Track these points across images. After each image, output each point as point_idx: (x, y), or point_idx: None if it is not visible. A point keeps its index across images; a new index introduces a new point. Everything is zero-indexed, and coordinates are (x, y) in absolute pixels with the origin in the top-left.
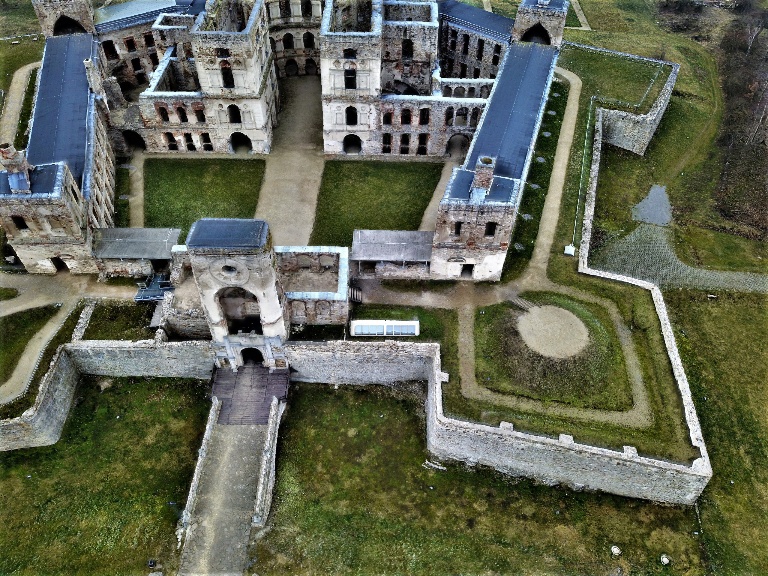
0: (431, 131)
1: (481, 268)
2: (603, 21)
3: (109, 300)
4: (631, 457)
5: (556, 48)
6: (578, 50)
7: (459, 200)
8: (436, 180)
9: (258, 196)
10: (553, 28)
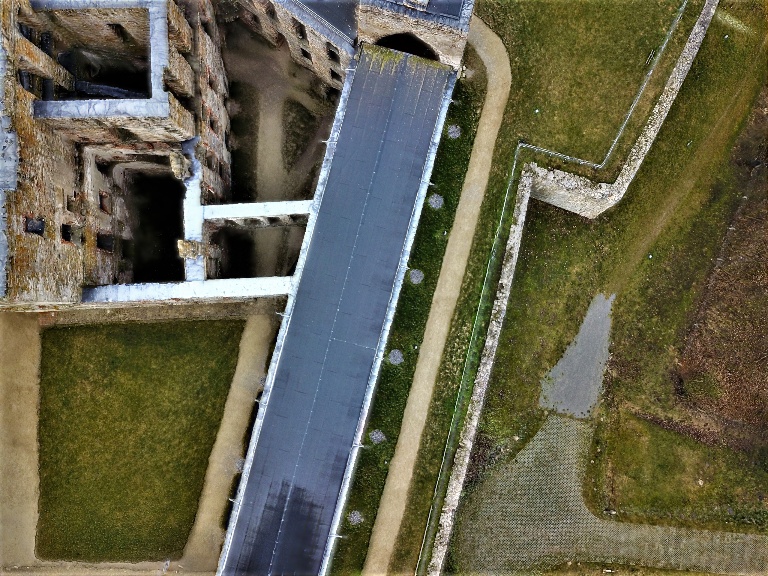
0: None
1: None
2: None
3: None
4: None
5: (451, 69)
6: None
7: None
8: (229, 371)
9: None
10: (442, 44)
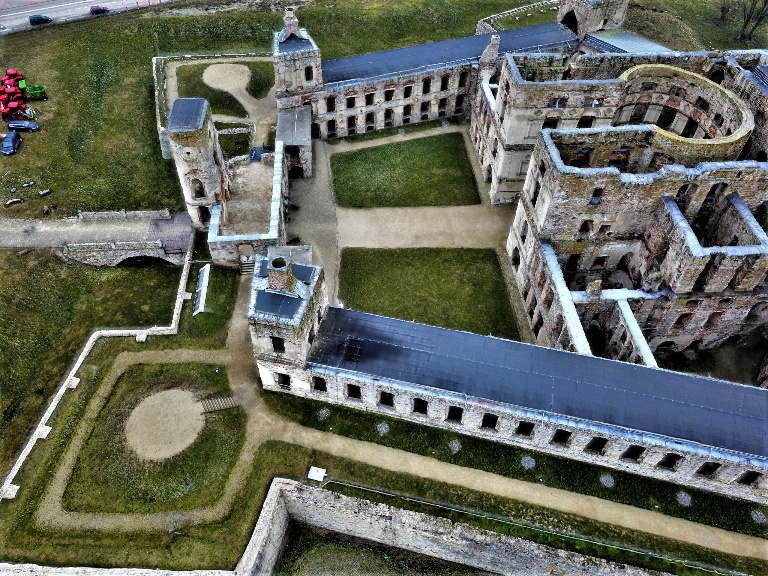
0: (546, 322)
1: None
2: None
3: (253, 137)
4: (2, 489)
5: None
6: None
7: None
8: None
9: (418, 206)
10: None
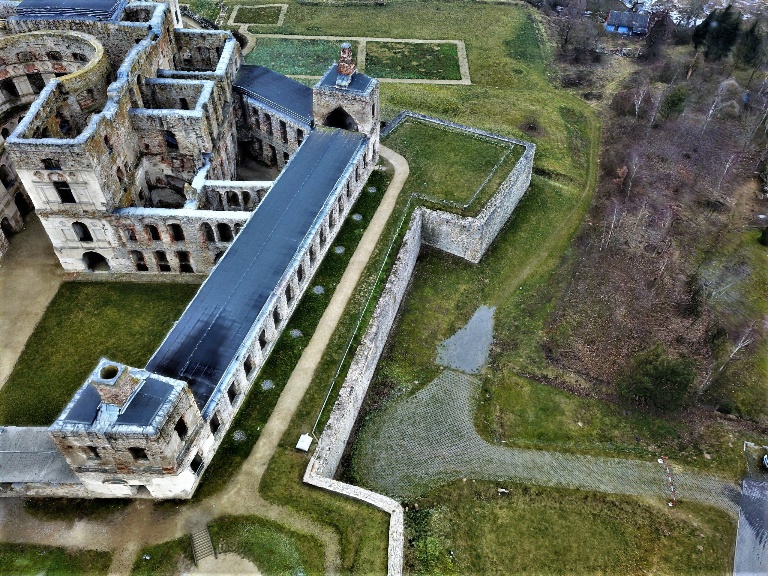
0: (190, 248)
1: (155, 488)
2: (487, 73)
3: None
4: None
5: (365, 136)
6: (420, 125)
7: (78, 423)
8: None
9: None
10: (357, 113)
